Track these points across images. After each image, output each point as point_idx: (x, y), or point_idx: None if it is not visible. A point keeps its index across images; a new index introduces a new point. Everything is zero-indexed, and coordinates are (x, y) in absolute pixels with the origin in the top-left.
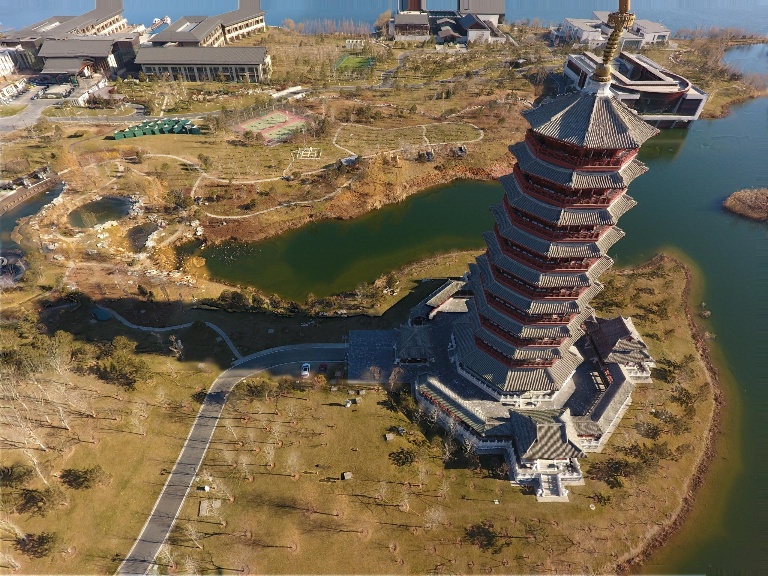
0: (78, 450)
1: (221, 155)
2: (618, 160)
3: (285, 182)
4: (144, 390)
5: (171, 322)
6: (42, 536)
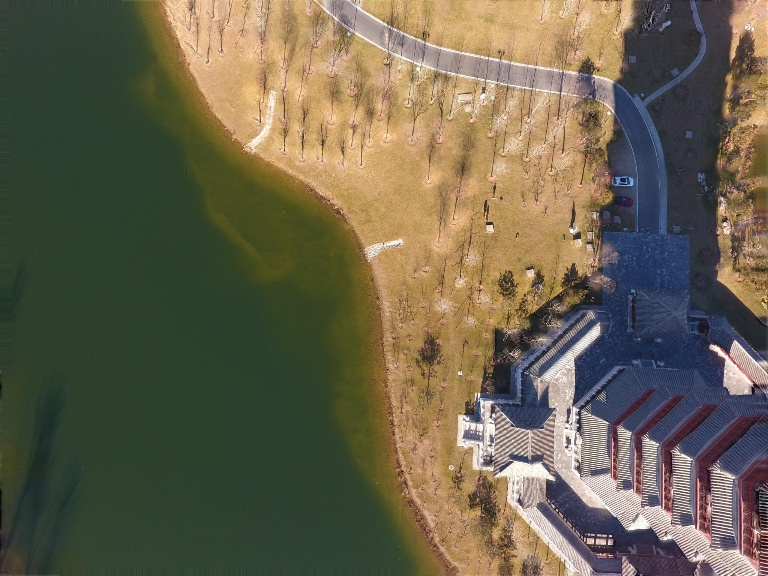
0: None
1: None
2: None
3: None
4: (597, 4)
5: (706, 7)
6: None
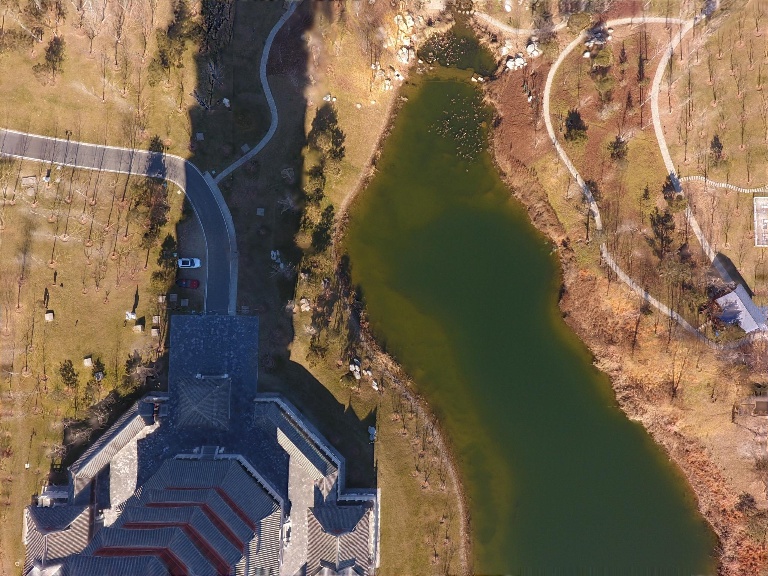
0: (83, 42)
1: (767, 39)
2: None
3: (659, 184)
4: None
5: (278, 80)
6: (7, 47)
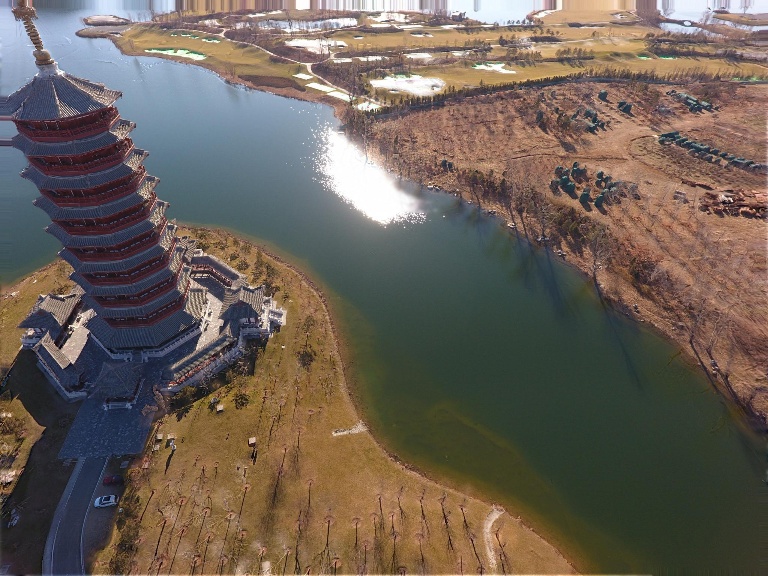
0: None
1: None
2: (117, 110)
3: None
4: None
5: None
6: None
